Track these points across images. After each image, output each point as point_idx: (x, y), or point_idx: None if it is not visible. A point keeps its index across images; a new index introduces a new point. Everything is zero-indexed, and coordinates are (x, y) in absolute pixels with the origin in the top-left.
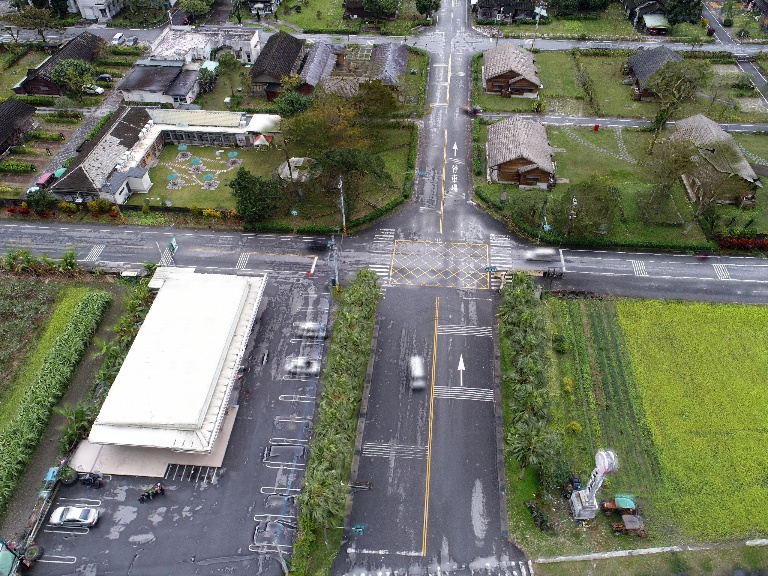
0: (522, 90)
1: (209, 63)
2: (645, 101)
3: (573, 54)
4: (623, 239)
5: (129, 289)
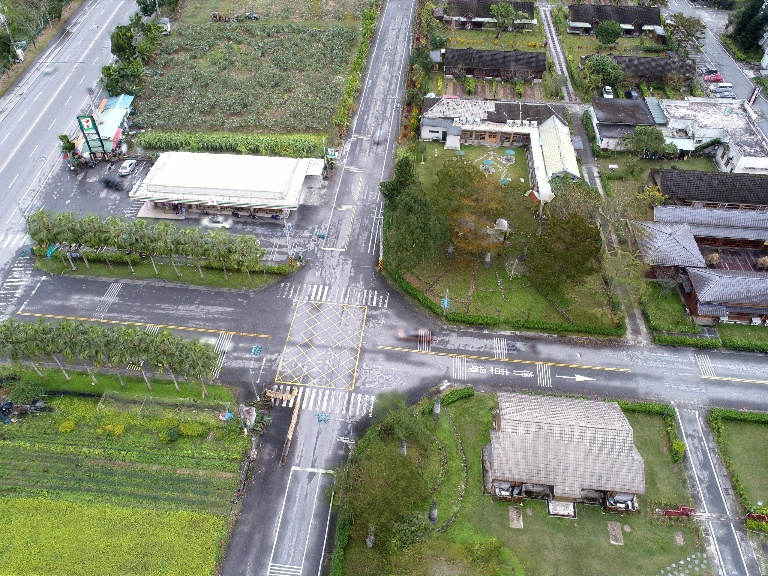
0: None
1: (686, 142)
2: None
3: None
4: (353, 569)
5: None
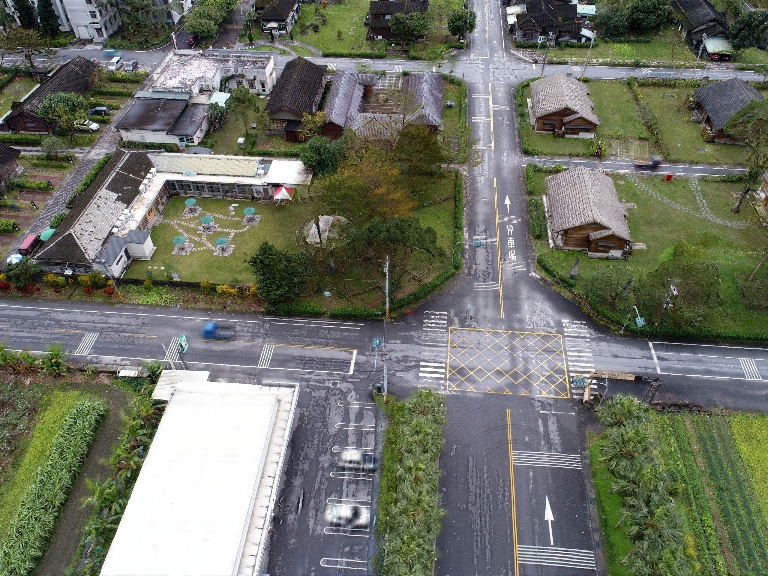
0: (578, 129)
1: (219, 95)
2: (719, 143)
3: (629, 84)
4: (724, 328)
5: (128, 393)
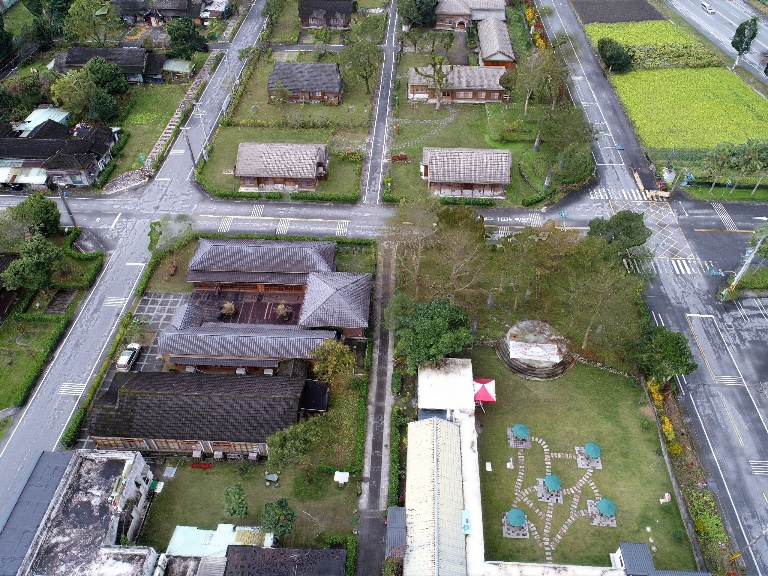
0: None
1: (181, 546)
2: (340, 100)
3: (229, 125)
4: None
5: None
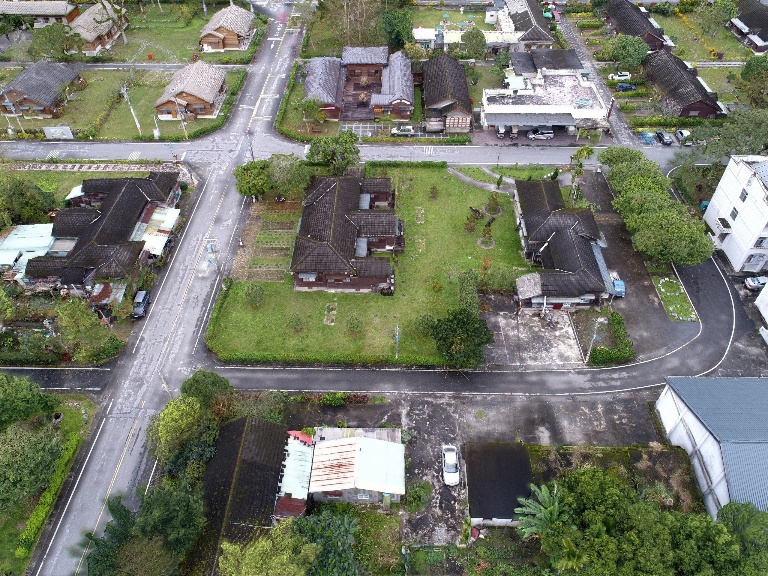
0: None
1: (520, 86)
2: None
3: None
4: None
5: None
